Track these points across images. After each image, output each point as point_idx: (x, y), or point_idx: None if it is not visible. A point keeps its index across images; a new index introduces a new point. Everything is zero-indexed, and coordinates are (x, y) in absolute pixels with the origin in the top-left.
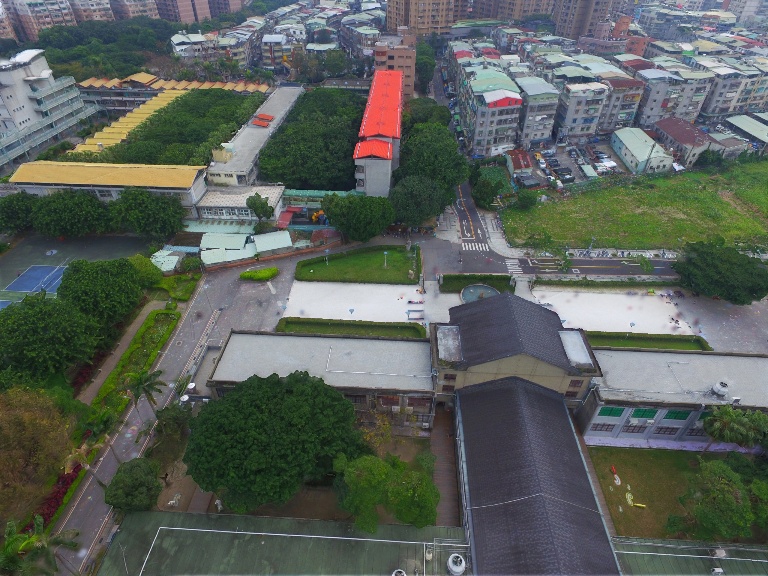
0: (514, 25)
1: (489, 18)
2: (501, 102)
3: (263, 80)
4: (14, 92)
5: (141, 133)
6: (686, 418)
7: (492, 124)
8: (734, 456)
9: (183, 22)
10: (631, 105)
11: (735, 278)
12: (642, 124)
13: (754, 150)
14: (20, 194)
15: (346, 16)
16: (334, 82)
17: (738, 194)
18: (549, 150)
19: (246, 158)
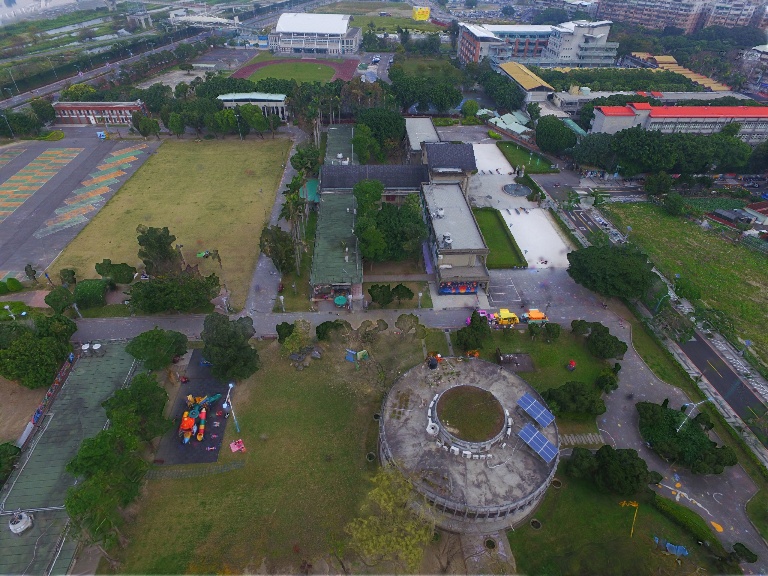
0: None
1: None
2: None
3: (731, 83)
4: (572, 39)
5: (577, 72)
6: None
7: None
8: None
9: None
10: None
11: (590, 259)
12: None
13: None
14: (496, 72)
15: None
16: None
17: None
18: None
19: (583, 98)
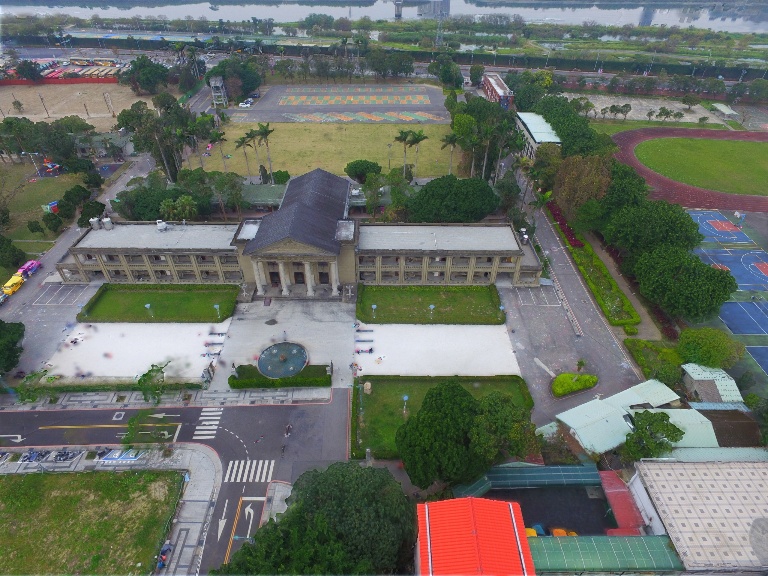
0: None
1: None
2: None
3: None
4: None
5: None
6: None
7: None
8: None
9: None
10: None
11: None
12: None
13: None
14: None
15: None
16: None
17: None
18: None
19: None
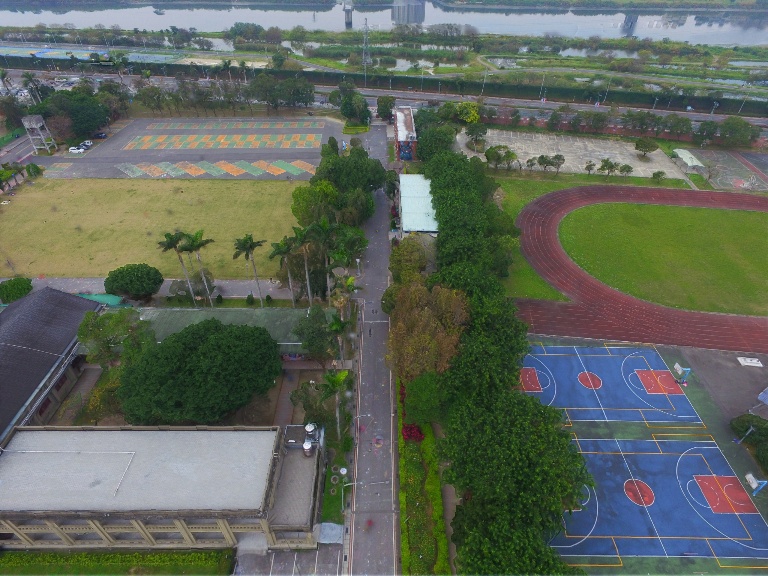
0: None
1: None
2: None
3: None
4: None
5: None
6: None
7: None
8: None
9: None
10: None
11: None
12: None
13: None
14: None
15: None
16: None
17: None
18: None
19: None
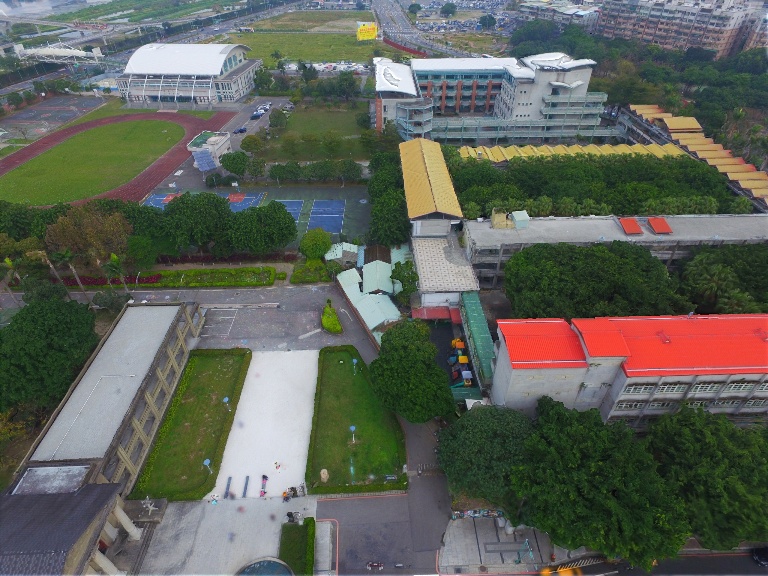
0: None
1: None
2: None
3: None
4: (531, 90)
5: (522, 163)
6: None
7: None
8: None
9: None
10: None
11: None
12: None
13: None
14: (392, 155)
15: None
16: None
17: None
18: None
19: (513, 238)
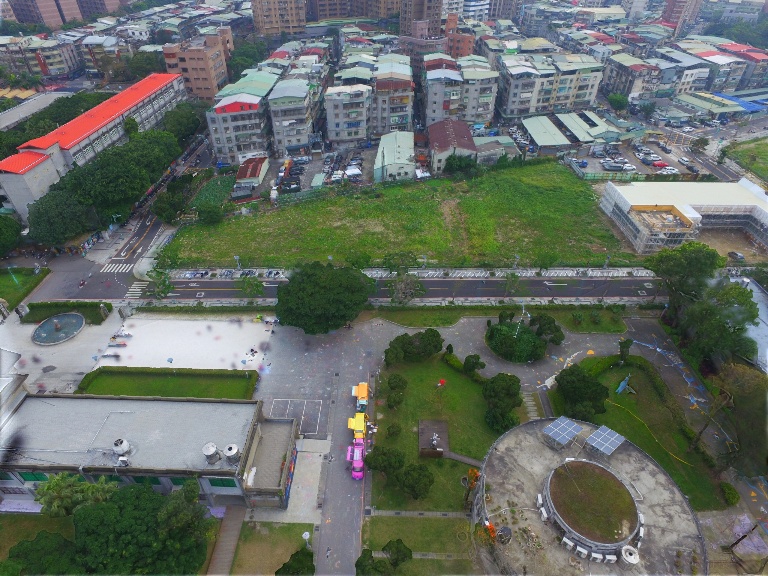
0: (363, 24)
1: (362, 16)
2: (230, 107)
3: None
4: None
5: None
6: (86, 480)
7: (227, 130)
8: (38, 537)
9: (31, 23)
10: (403, 108)
11: (309, 305)
12: (414, 128)
13: (517, 154)
14: None
15: (210, 16)
16: (107, 86)
17: (460, 203)
18: (304, 157)
19: None
